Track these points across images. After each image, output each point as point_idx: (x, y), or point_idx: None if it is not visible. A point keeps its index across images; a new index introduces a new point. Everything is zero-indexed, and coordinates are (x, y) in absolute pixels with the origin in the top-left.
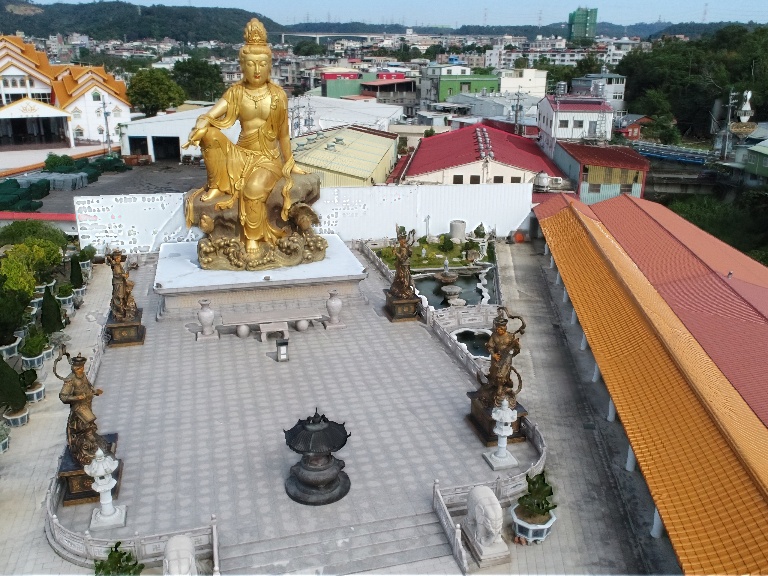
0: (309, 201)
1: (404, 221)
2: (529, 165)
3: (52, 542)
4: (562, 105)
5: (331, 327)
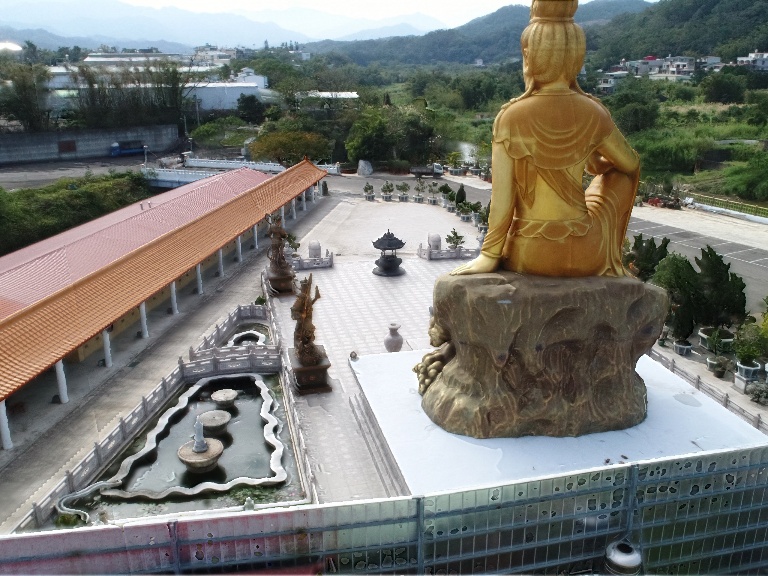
0: None
1: None
2: None
3: None
4: None
5: None
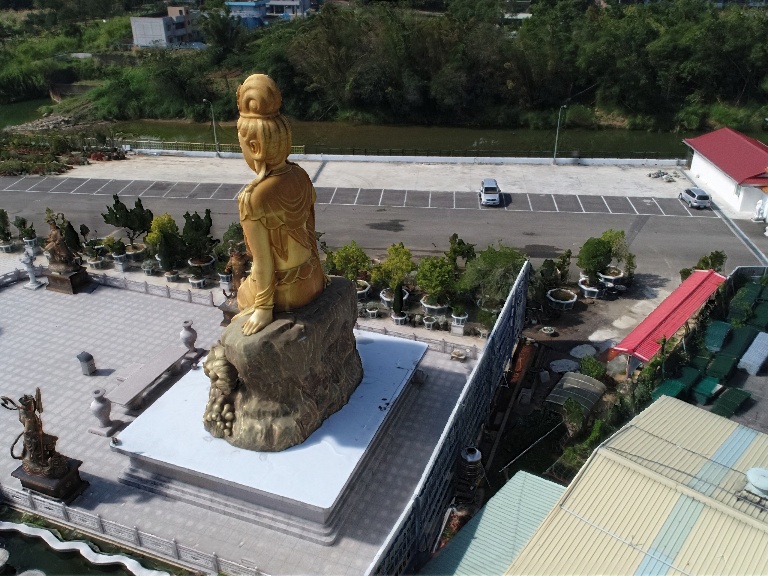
0: None
1: None
2: None
3: None
4: None
5: None
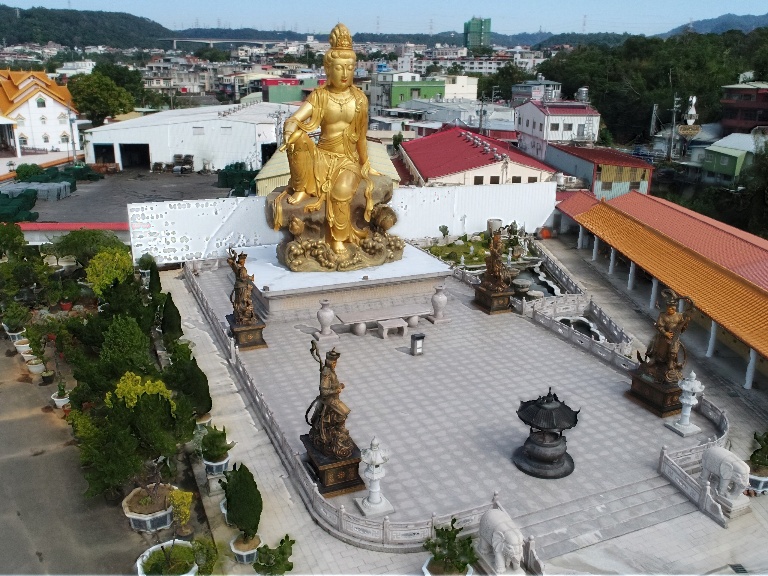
0: (384, 202)
1: (442, 221)
2: (536, 166)
3: (337, 532)
4: (551, 109)
5: (438, 322)
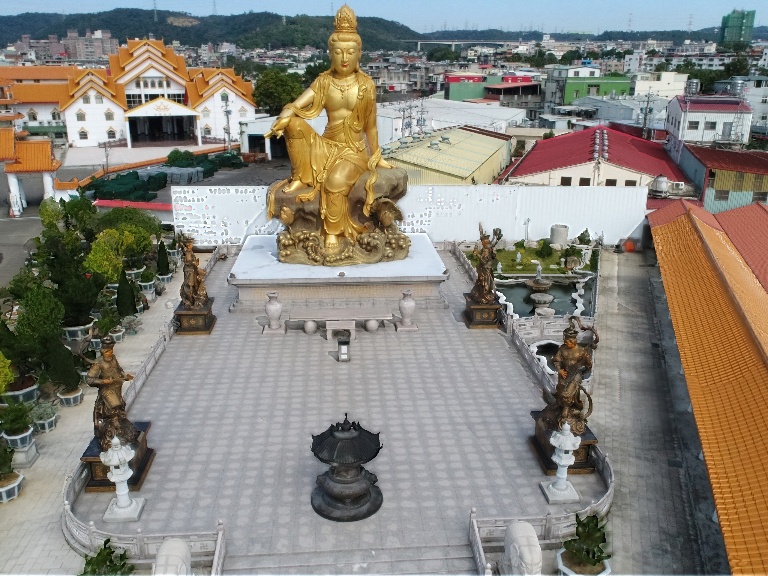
0: (394, 197)
1: (502, 223)
2: (648, 169)
3: (64, 529)
4: (693, 105)
5: (402, 329)
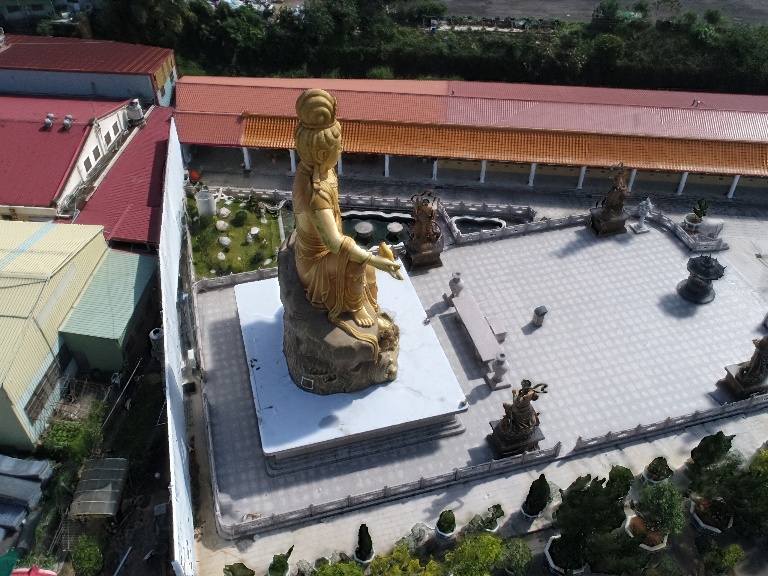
0: None
1: None
2: (57, 107)
3: None
4: None
5: None
